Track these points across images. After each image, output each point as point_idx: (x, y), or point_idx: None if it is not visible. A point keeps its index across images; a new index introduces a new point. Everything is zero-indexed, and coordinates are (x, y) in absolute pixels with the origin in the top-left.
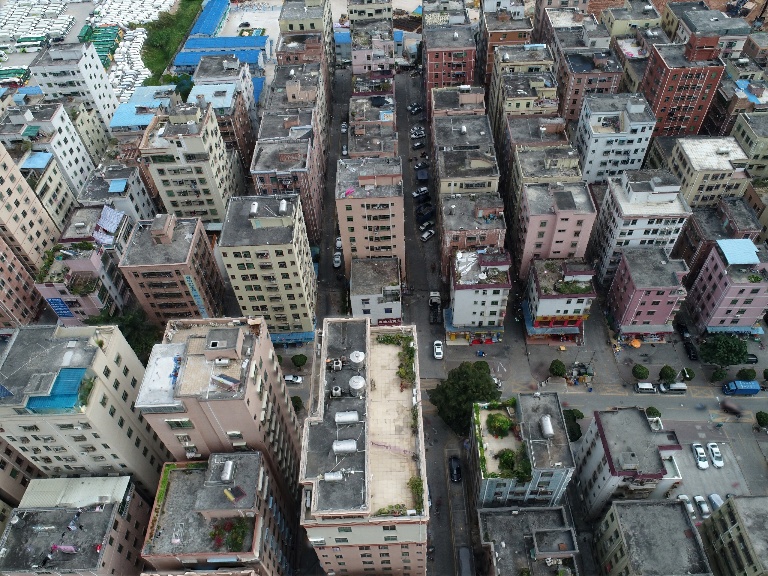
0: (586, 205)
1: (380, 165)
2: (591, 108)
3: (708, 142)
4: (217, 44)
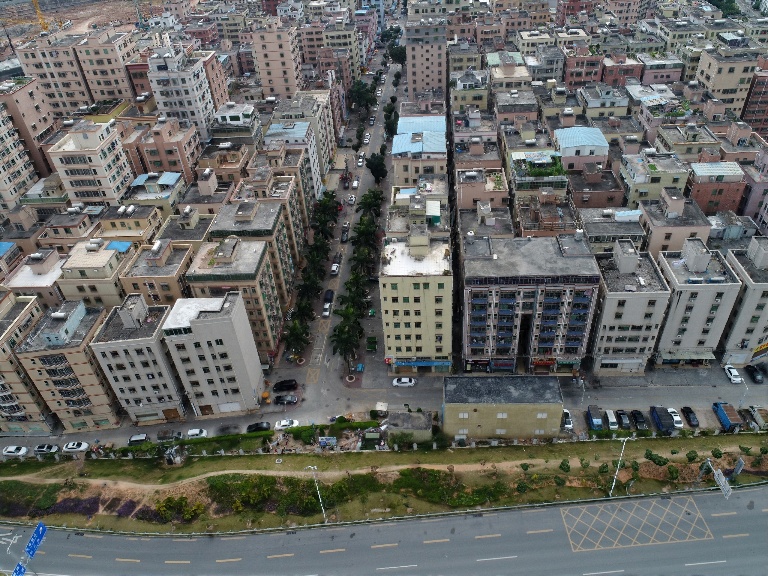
0: None
1: (312, 19)
2: (286, 6)
3: (311, 3)
4: None
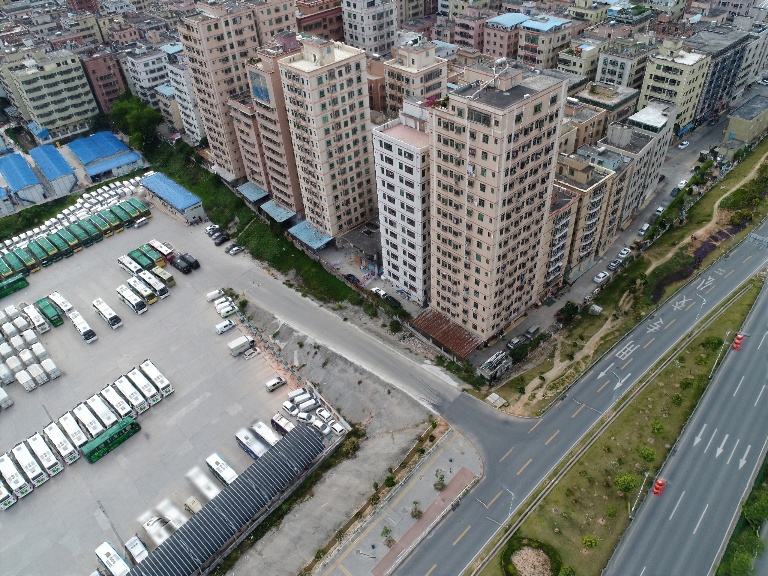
0: (181, 3)
1: None
2: (122, 2)
3: None
4: (26, 171)
